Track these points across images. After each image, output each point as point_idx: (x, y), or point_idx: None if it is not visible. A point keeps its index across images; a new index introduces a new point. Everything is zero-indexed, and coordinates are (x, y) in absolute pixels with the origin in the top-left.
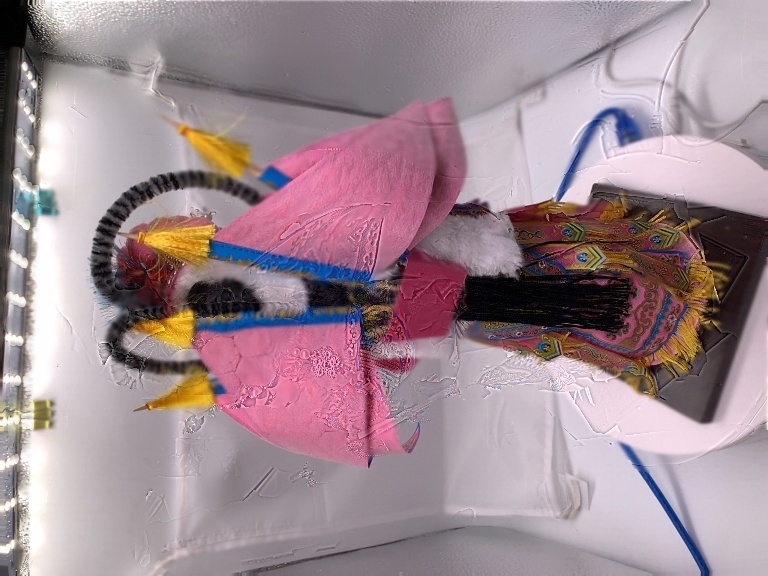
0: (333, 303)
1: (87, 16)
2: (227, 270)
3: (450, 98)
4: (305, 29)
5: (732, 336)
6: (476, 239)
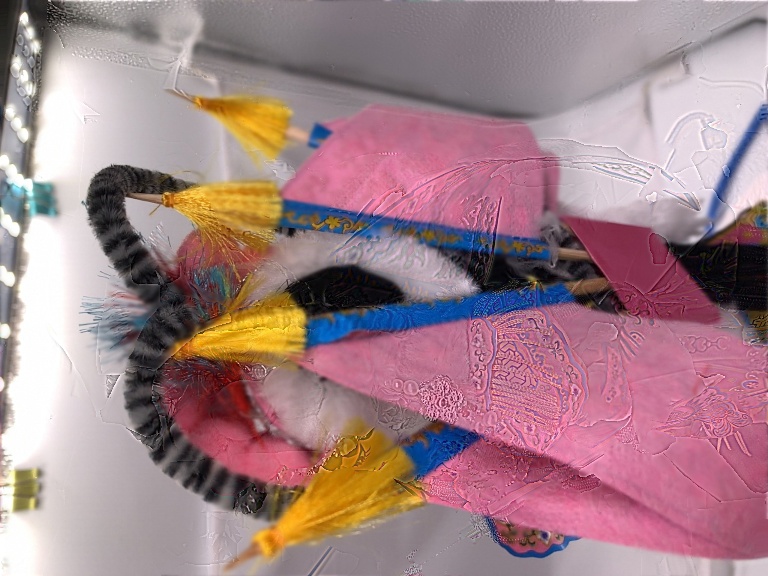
0: (442, 314)
1: (100, 5)
2: (304, 255)
3: (517, 96)
4: (353, 14)
5: None
6: (765, 159)
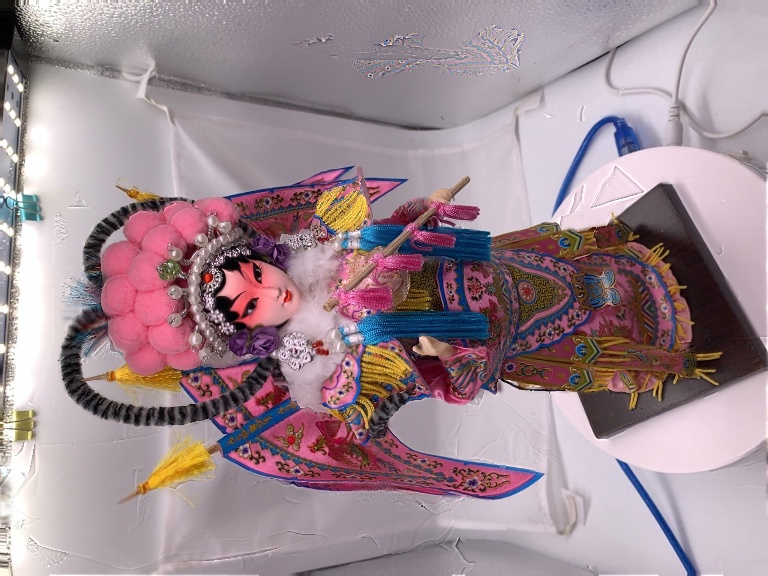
0: None
1: None
2: None
3: None
4: None
5: (685, 194)
6: None
